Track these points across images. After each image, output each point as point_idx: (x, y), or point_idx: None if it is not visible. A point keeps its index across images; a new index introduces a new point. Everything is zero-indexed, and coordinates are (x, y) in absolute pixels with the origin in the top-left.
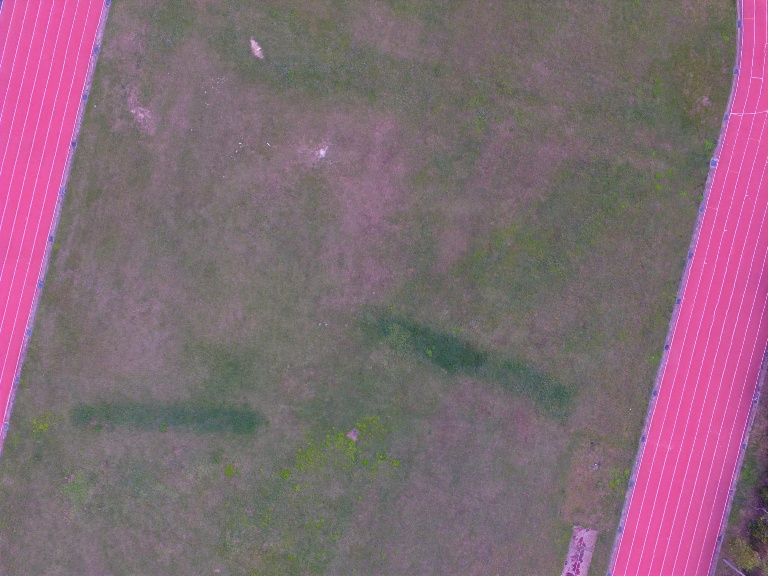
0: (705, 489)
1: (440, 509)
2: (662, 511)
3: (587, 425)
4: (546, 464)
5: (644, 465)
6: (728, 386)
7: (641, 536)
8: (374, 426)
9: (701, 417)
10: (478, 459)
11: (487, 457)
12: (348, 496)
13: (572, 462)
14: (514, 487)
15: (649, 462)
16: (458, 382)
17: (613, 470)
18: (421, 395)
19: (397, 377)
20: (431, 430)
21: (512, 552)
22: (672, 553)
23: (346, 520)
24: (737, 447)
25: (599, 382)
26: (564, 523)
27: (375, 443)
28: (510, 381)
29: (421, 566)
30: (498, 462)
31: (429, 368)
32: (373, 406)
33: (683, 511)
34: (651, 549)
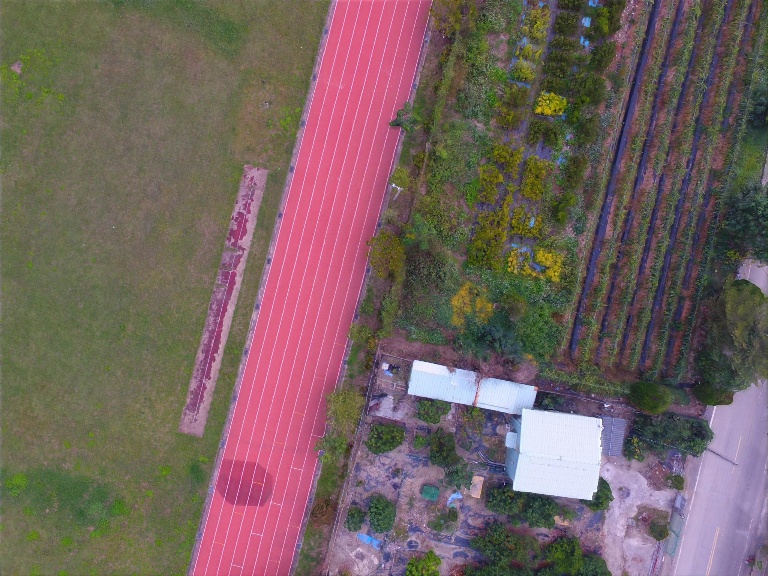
0: (376, 129)
1: (108, 145)
2: (333, 150)
3: (257, 63)
4: (216, 102)
5: (315, 104)
6: (399, 25)
7: (312, 176)
8: (39, 58)
9: (372, 56)
10: (147, 95)
11: (156, 93)
12: (13, 130)
13: (242, 100)
14: (184, 124)
15: (320, 101)
16: (125, 15)
17: (284, 108)
18: (87, 28)
19: (62, 9)
20: (98, 64)
21: (181, 190)
22: (343, 192)
23: (11, 154)
24: (408, 87)
25: (269, 19)
26: (235, 162)
27: (40, 76)
28: (178, 15)
29: (88, 202)
30: (167, 99)
31: (95, 0)
32: (38, 38)
33: (354, 150)
34: (322, 188)
